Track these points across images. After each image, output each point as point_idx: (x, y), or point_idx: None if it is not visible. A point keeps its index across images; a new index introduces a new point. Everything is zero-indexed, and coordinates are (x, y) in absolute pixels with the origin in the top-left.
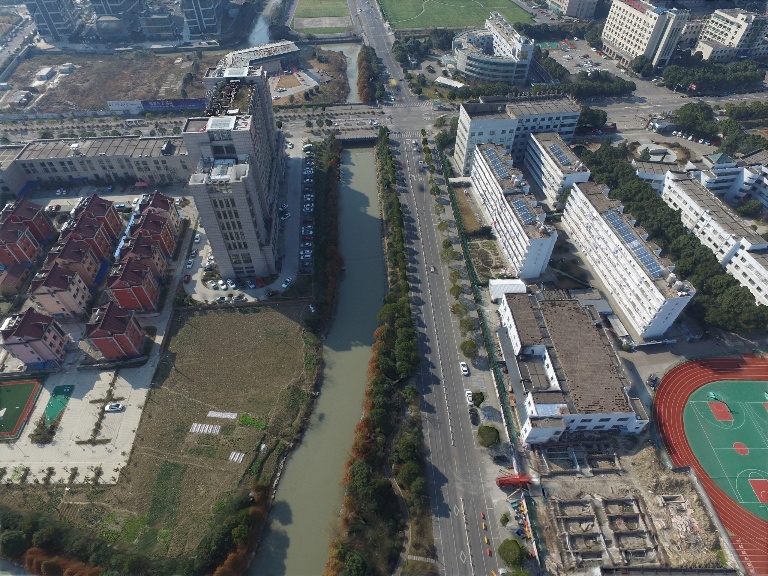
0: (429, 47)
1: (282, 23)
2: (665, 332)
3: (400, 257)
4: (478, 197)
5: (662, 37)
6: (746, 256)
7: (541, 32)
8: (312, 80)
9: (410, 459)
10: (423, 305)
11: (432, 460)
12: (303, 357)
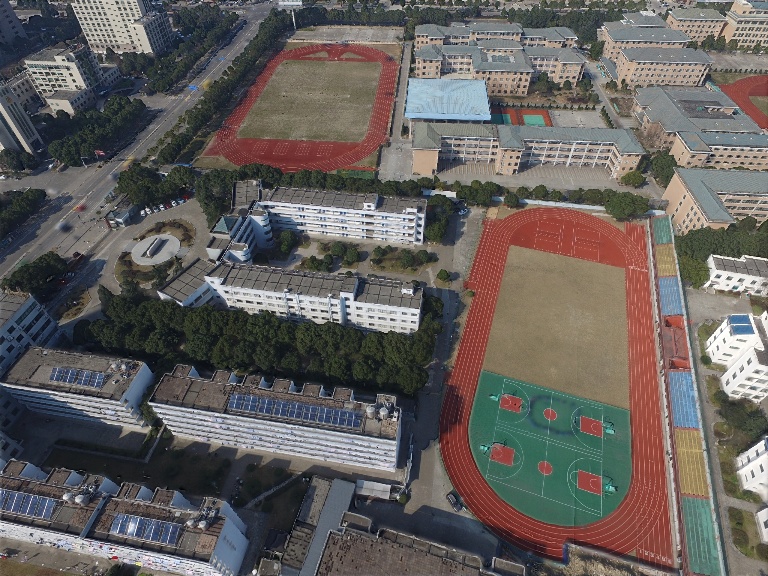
0: None
1: None
2: None
3: None
4: (35, 543)
5: (5, 121)
6: (359, 305)
7: None
8: None
9: None
10: None
11: None
12: None
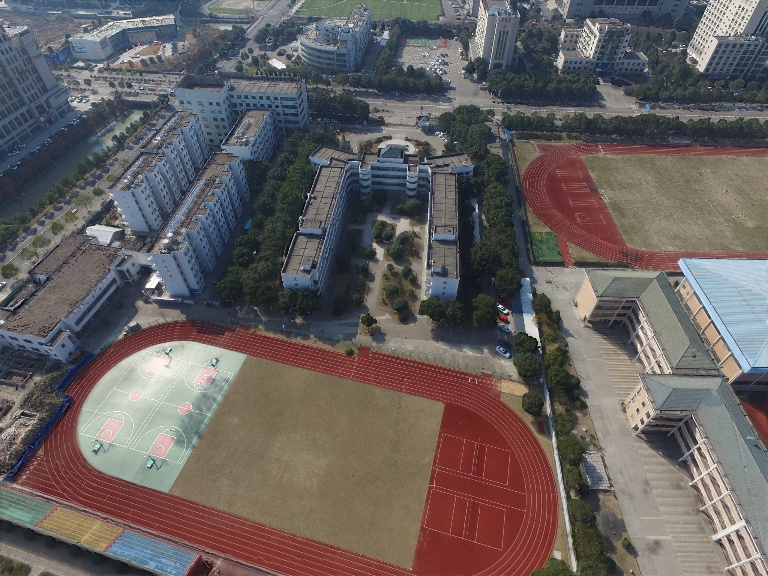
0: (297, 32)
1: (205, 2)
2: (195, 294)
3: None
4: None
5: (493, 39)
6: None
7: (420, 28)
8: (170, 51)
9: None
10: (32, 236)
11: None
12: None
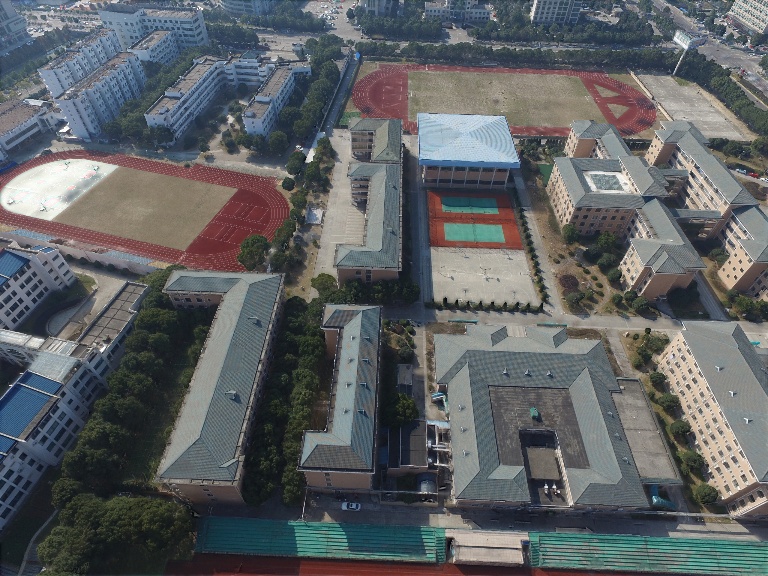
0: None
1: None
2: (93, 137)
3: None
4: None
5: None
6: None
7: None
8: (117, 0)
9: None
10: None
11: None
12: None
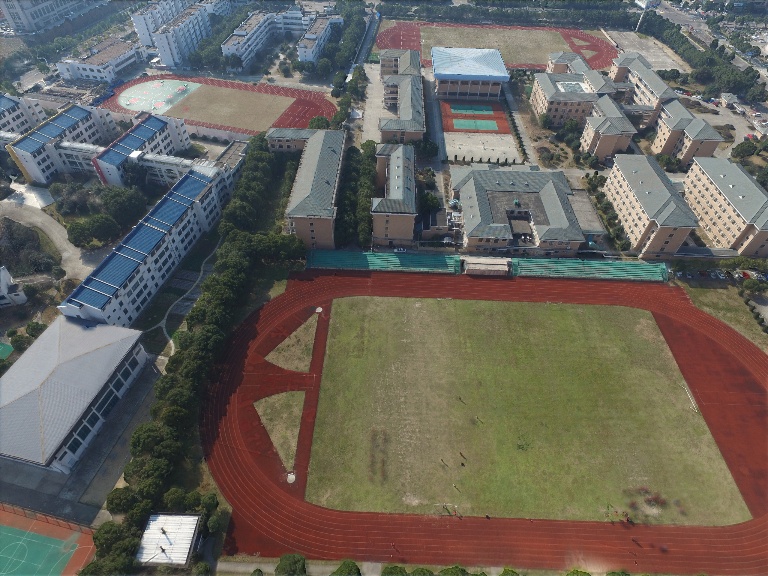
0: None
1: None
2: (177, 66)
3: (92, 29)
4: None
5: None
6: None
7: None
8: None
9: (3, 65)
10: None
11: None
12: (12, 50)
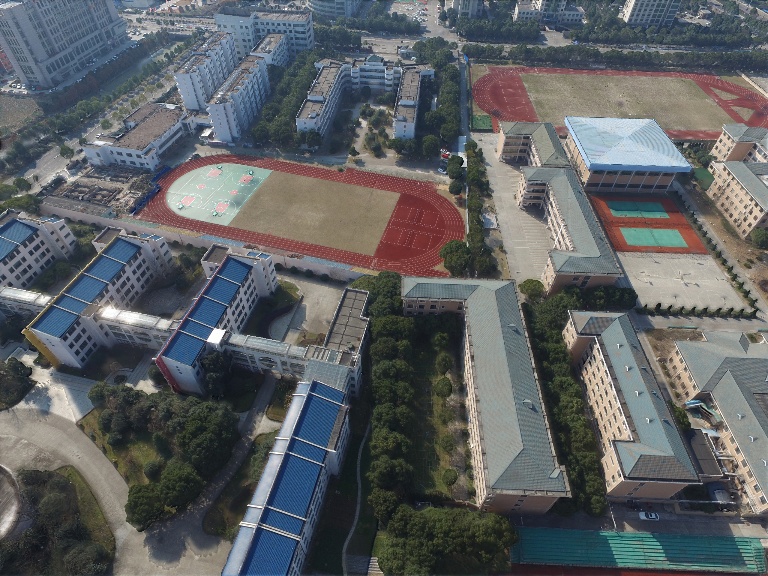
0: None
1: None
2: (235, 141)
3: (123, 86)
4: None
5: None
6: None
7: None
8: (201, 3)
9: (14, 148)
10: (115, 110)
11: (38, 161)
12: (24, 118)
